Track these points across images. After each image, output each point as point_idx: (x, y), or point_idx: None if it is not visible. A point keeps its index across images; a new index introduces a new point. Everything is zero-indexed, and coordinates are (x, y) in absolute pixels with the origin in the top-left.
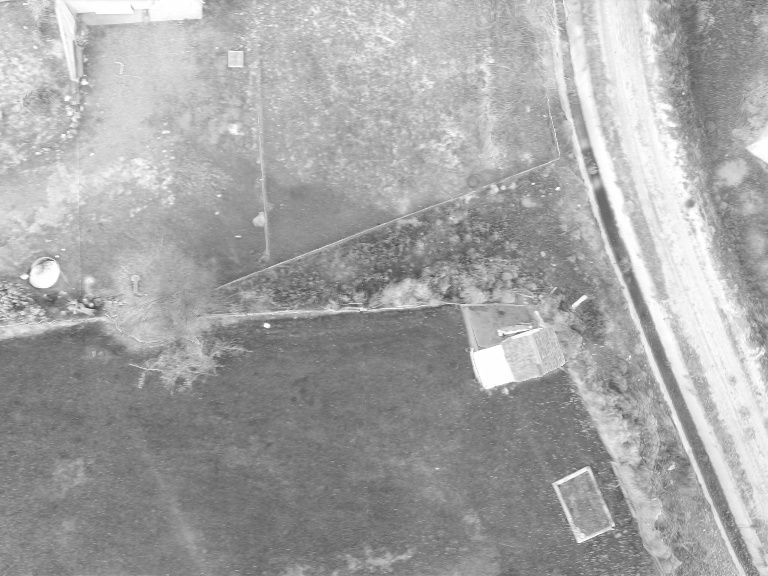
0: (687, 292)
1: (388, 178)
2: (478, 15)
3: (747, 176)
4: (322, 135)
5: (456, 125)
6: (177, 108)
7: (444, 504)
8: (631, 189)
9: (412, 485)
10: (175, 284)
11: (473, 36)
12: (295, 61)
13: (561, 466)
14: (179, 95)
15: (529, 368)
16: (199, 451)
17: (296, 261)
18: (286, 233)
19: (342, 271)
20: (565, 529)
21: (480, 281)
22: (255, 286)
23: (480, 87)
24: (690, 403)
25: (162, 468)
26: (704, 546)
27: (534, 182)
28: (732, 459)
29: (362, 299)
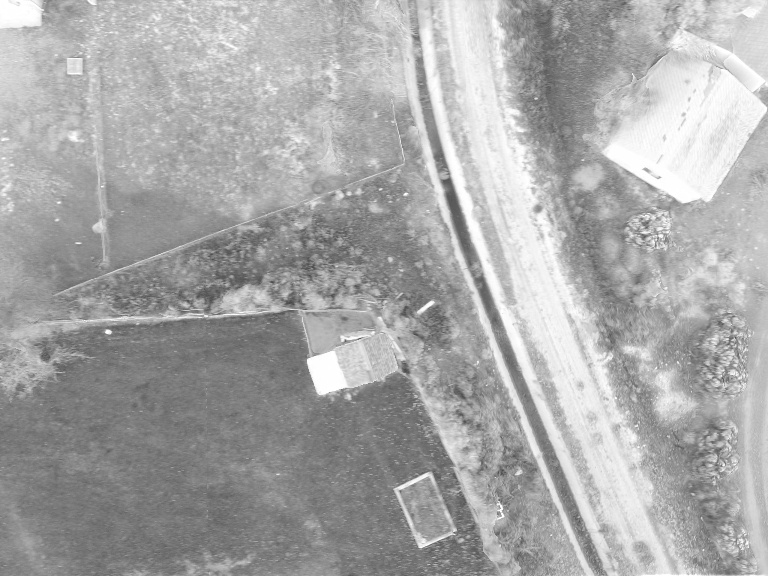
0: (535, 297)
1: (231, 184)
2: (324, 21)
3: (603, 181)
4: (163, 142)
5: (301, 131)
6: (16, 115)
7: (285, 510)
8: (480, 194)
9: (252, 491)
10: (12, 291)
11: (319, 42)
12: (136, 68)
13: (403, 471)
14: (18, 102)
15: (360, 374)
16: (39, 457)
17: (136, 268)
18: (127, 240)
19: (184, 277)
20: (407, 534)
21: (321, 287)
22: (95, 293)
23: (326, 93)
24: (540, 408)
25: (2, 474)
26: (551, 551)
27: (381, 188)
28: (580, 464)
29: (202, 305)
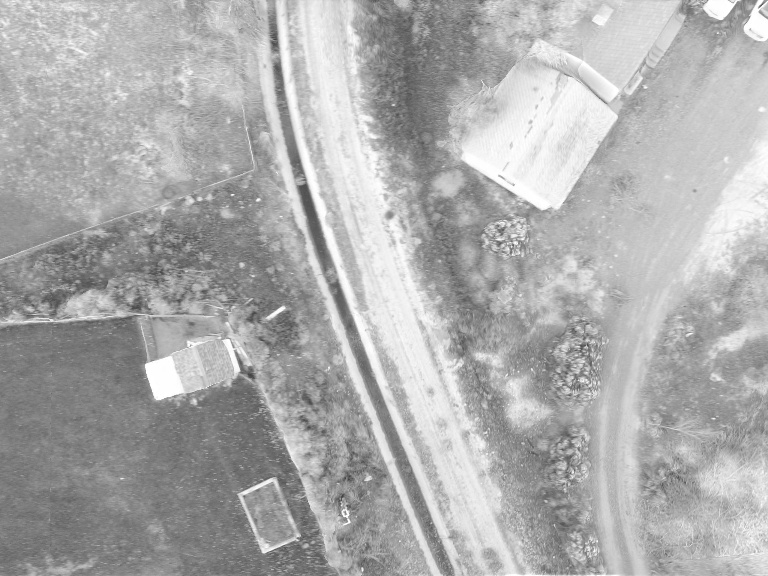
0: (387, 303)
1: (79, 189)
2: (176, 27)
3: (463, 187)
4: (11, 146)
5: (151, 136)
6: None
7: (128, 514)
8: (333, 200)
9: (95, 495)
10: None
11: (171, 48)
12: None
13: (248, 477)
14: None
15: (194, 380)
16: None
17: None
18: None
19: (30, 282)
20: (251, 539)
21: (167, 292)
22: None
23: (177, 99)
24: (393, 414)
25: None
26: (399, 557)
27: (233, 193)
28: (429, 470)
29: (47, 310)
